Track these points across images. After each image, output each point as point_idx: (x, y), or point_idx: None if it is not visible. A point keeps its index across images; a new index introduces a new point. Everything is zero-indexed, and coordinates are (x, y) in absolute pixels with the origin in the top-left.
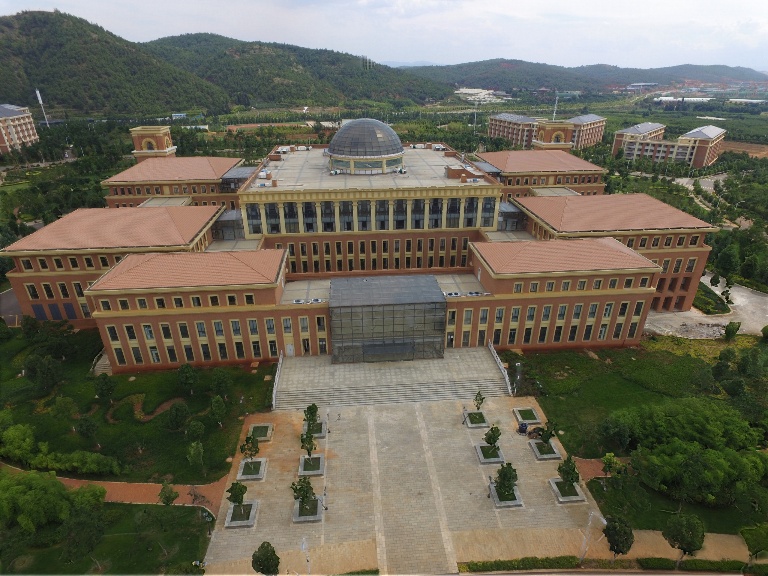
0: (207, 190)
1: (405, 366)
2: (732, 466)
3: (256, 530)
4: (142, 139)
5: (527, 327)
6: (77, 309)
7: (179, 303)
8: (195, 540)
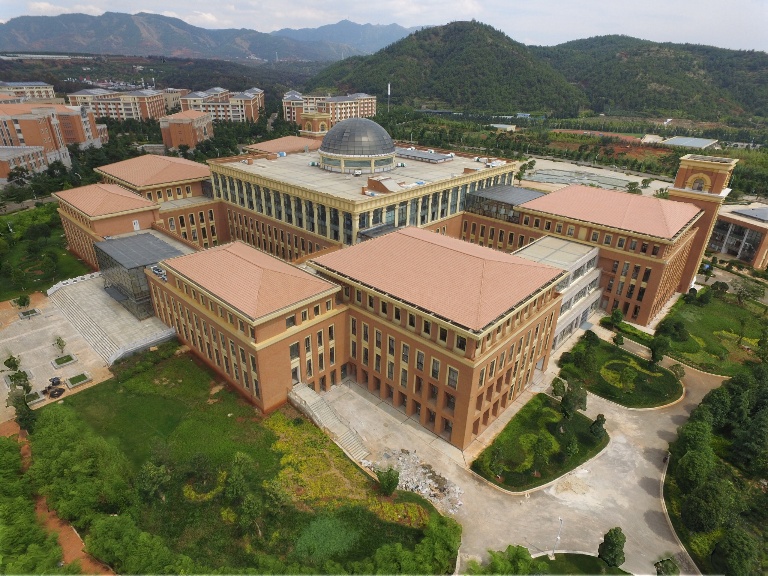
0: None
1: (119, 312)
2: None
3: None
4: (306, 121)
5: None
6: None
7: None
8: None
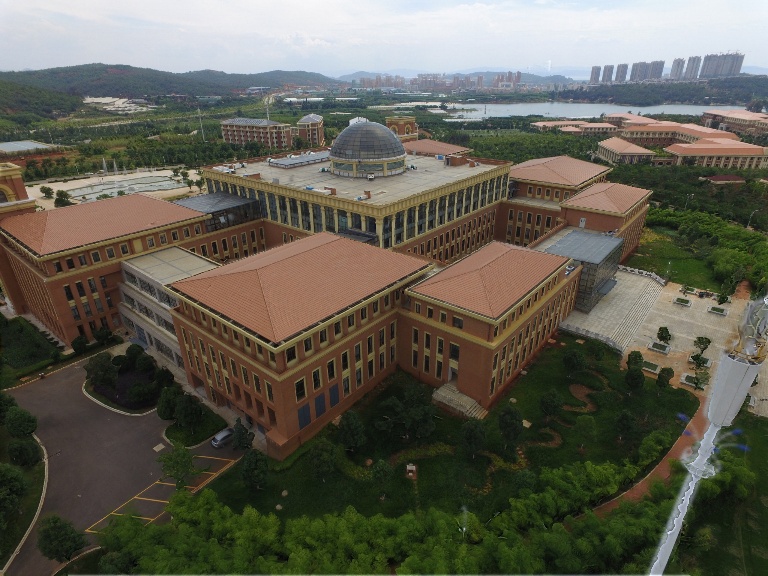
0: (191, 232)
1: (613, 295)
2: None
3: (759, 398)
4: None
5: None
6: (340, 389)
7: None
8: (762, 422)
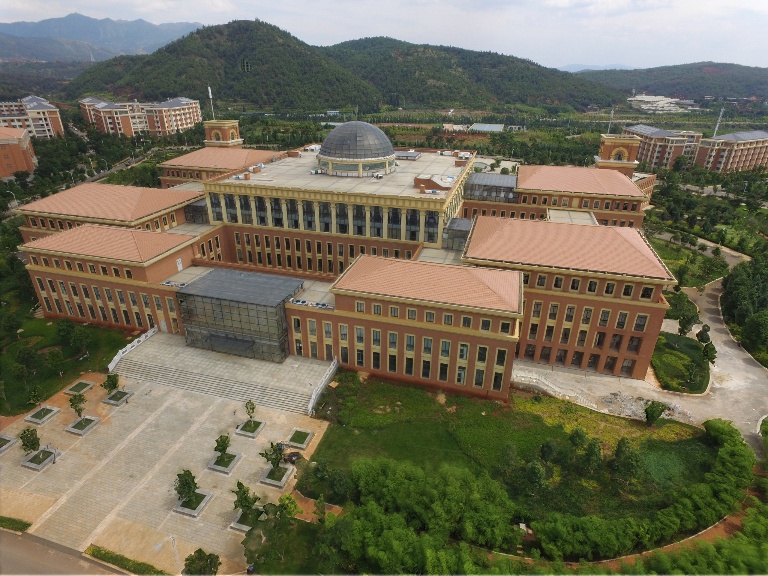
0: None
1: (241, 362)
2: (415, 554)
3: None
4: (212, 130)
5: (375, 351)
6: None
7: (82, 268)
8: None
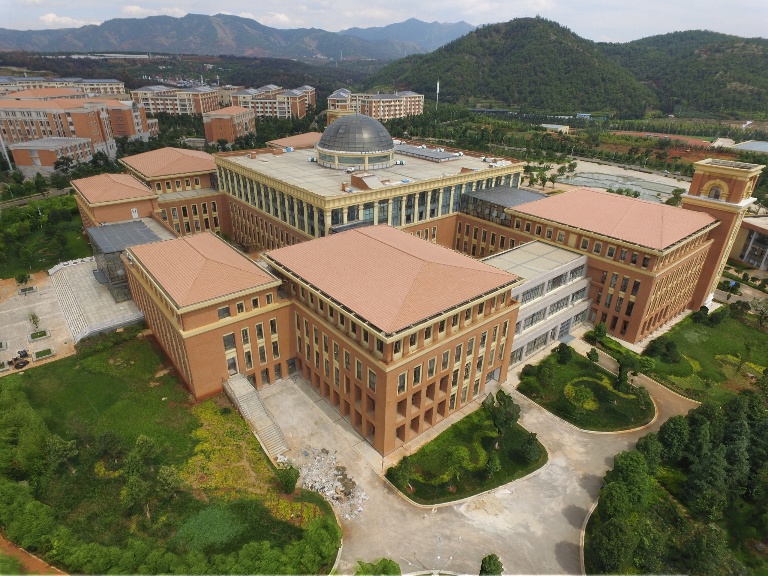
0: None
1: (102, 294)
2: None
3: None
4: (331, 118)
5: None
6: None
7: None
8: None
